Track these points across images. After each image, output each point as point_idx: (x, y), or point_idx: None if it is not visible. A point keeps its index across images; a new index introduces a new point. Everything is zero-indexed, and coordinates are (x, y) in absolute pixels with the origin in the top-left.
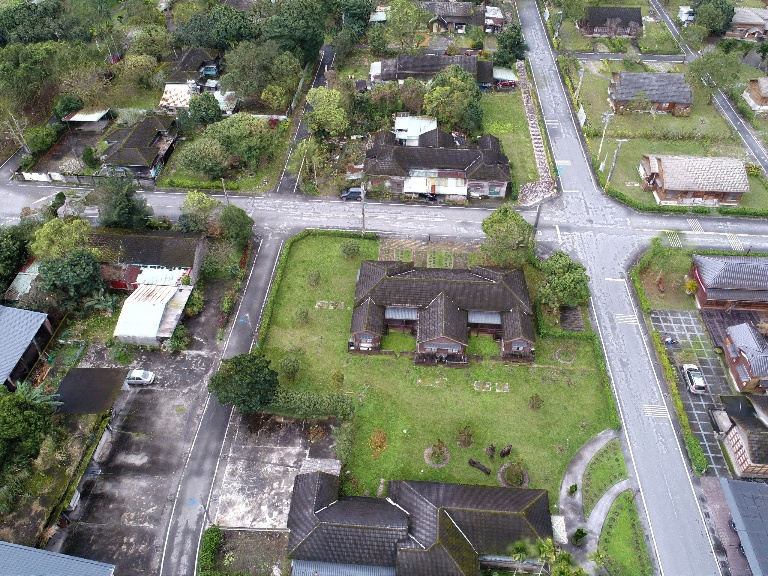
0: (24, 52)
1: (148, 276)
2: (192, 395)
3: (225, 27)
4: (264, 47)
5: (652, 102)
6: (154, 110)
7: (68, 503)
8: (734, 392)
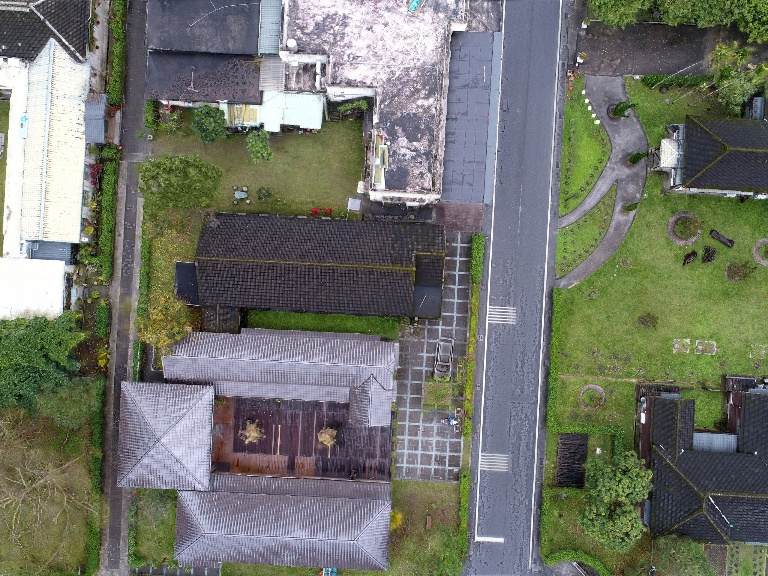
0: None
1: None
2: None
3: None
4: None
5: None
6: None
7: None
8: None
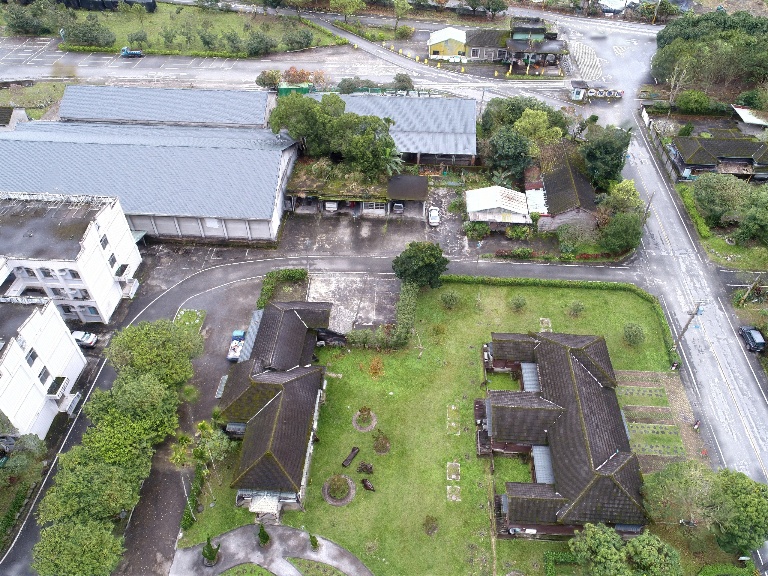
0: None
1: (535, 195)
2: None
3: None
4: None
5: None
6: None
7: (322, 199)
8: None
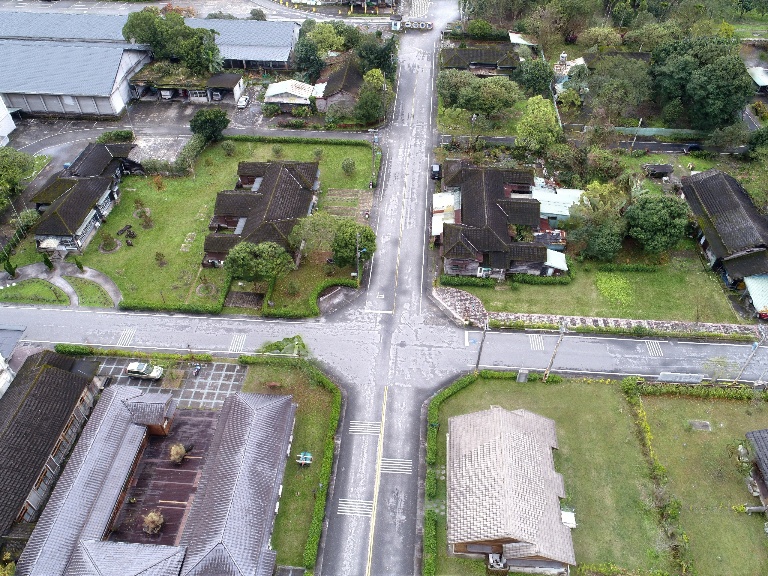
0: None
1: (320, 86)
2: None
3: None
4: None
5: None
6: None
7: (156, 87)
8: None
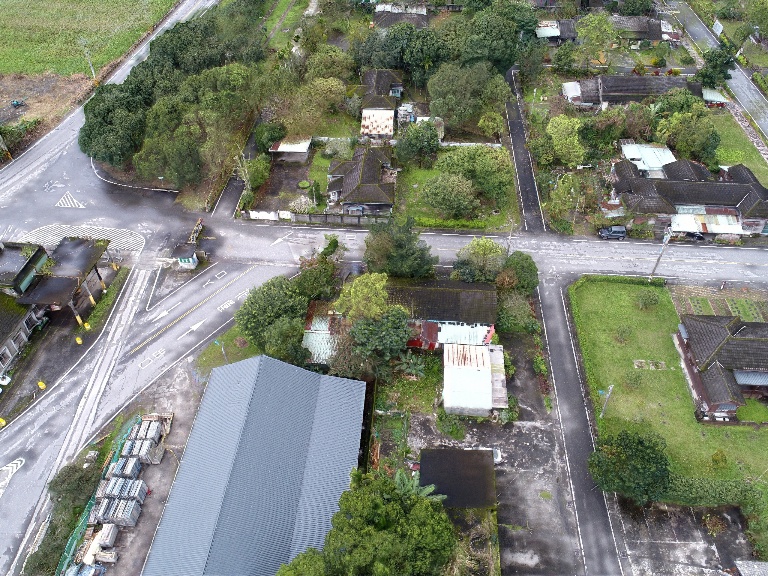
0: (223, 78)
1: (449, 334)
2: (550, 477)
3: (421, 48)
4: (471, 70)
5: None
6: (360, 139)
7: None
8: None
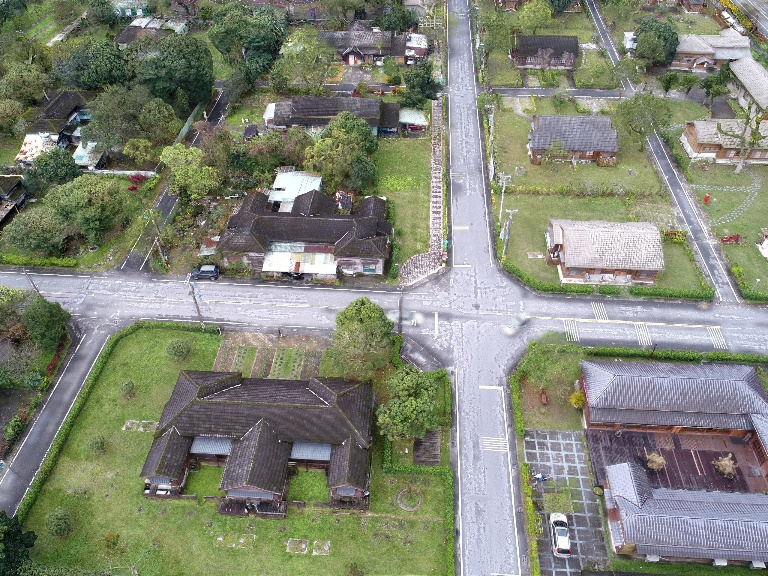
0: None
1: None
2: None
3: (96, 68)
4: (133, 93)
5: (573, 151)
6: (5, 166)
7: None
8: (609, 553)
